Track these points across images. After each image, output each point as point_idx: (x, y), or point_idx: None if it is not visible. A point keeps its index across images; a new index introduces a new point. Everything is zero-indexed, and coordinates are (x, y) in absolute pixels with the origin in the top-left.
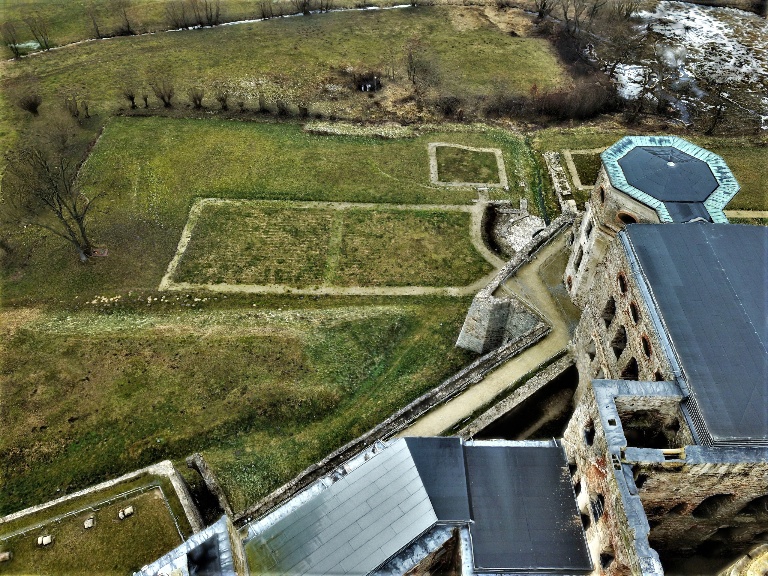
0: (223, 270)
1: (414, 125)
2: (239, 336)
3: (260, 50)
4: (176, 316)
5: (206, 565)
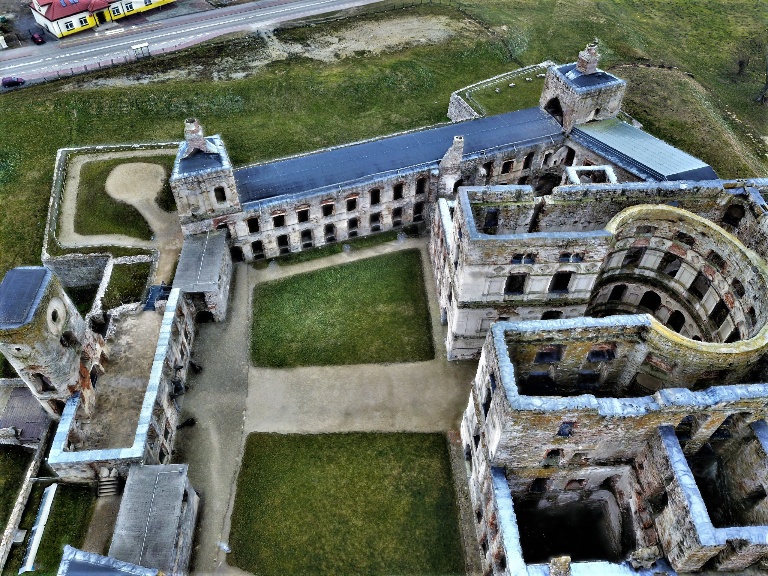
0: None
1: None
2: (748, 165)
3: None
4: (745, 146)
5: (603, 77)
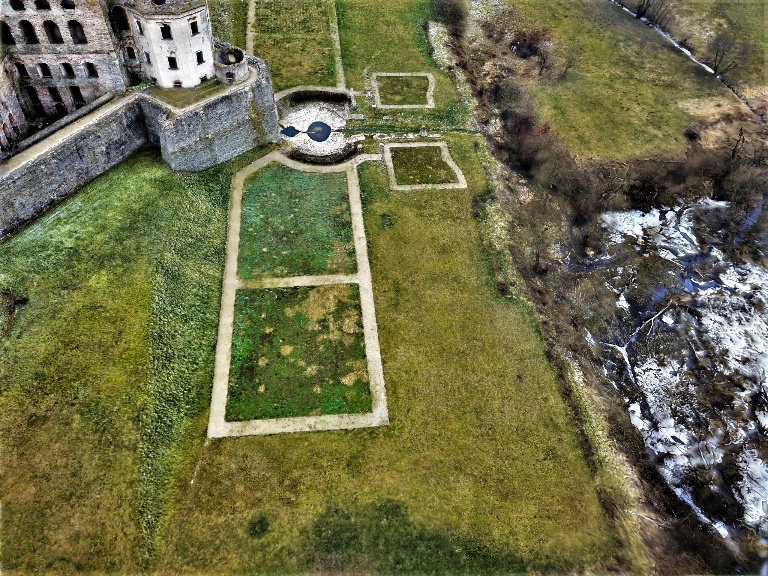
0: (267, 3)
1: (459, 69)
2: None
3: (551, 2)
4: None
5: None
